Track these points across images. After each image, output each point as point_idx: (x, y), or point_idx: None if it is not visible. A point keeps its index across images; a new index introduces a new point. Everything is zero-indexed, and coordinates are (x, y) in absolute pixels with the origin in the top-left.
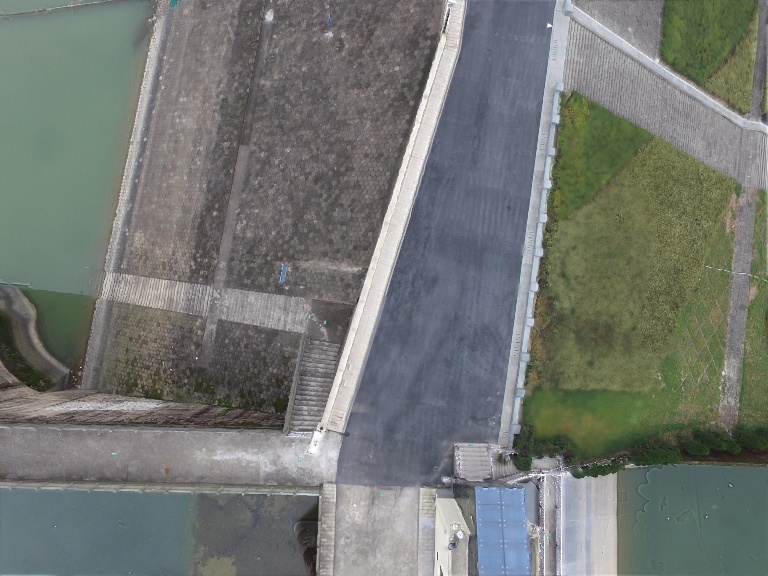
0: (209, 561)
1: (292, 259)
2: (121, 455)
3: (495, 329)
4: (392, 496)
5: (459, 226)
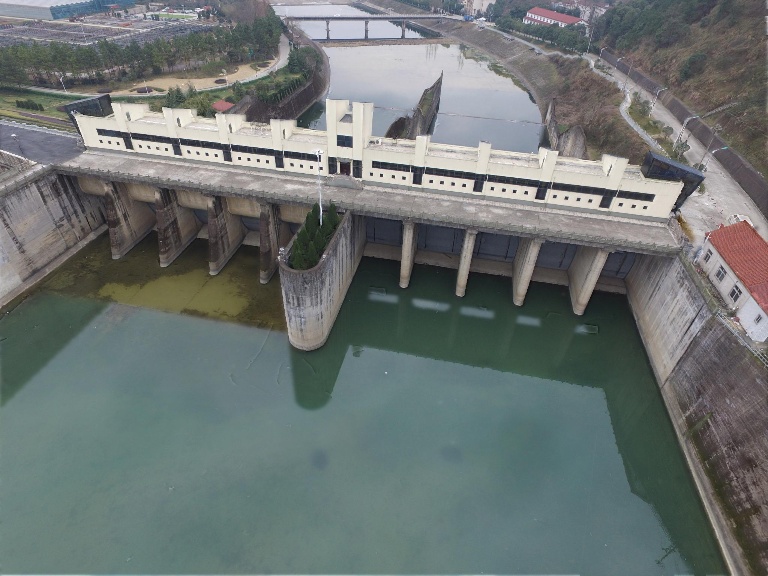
0: (99, 293)
1: None
2: None
3: None
4: (78, 158)
5: (1, 137)
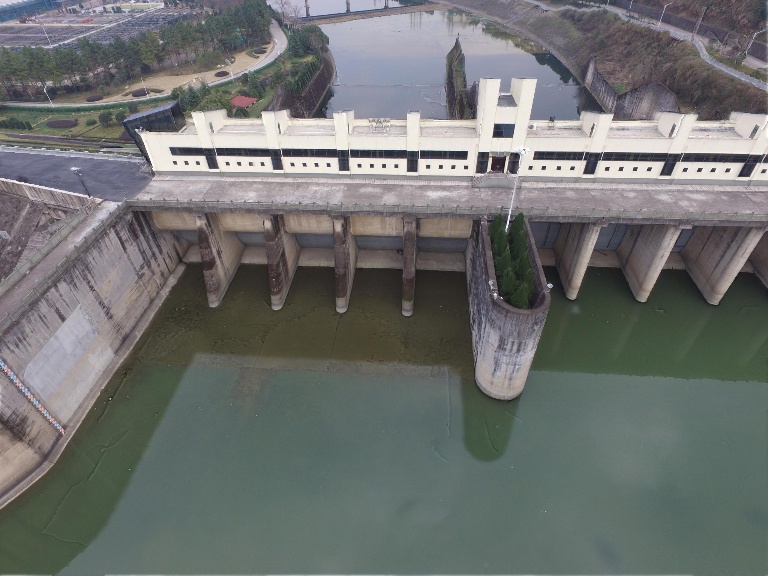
0: (214, 355)
1: (4, 246)
2: (40, 277)
3: (97, 163)
4: None
5: None
